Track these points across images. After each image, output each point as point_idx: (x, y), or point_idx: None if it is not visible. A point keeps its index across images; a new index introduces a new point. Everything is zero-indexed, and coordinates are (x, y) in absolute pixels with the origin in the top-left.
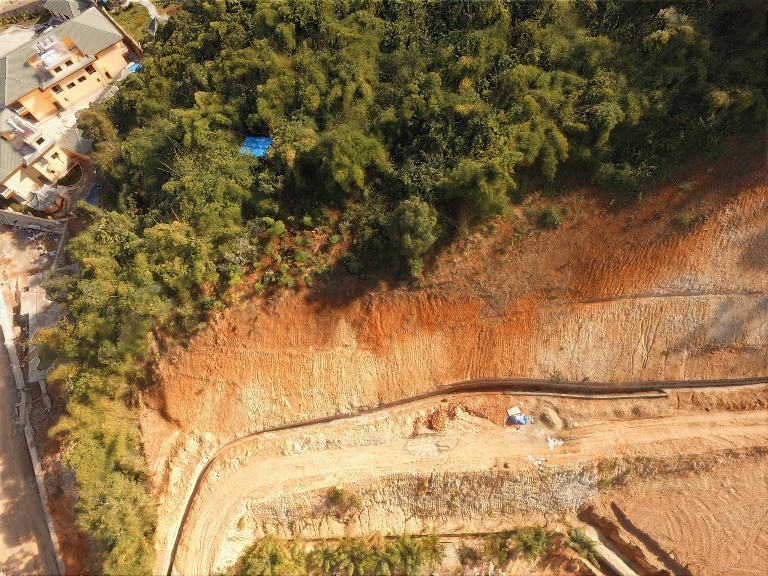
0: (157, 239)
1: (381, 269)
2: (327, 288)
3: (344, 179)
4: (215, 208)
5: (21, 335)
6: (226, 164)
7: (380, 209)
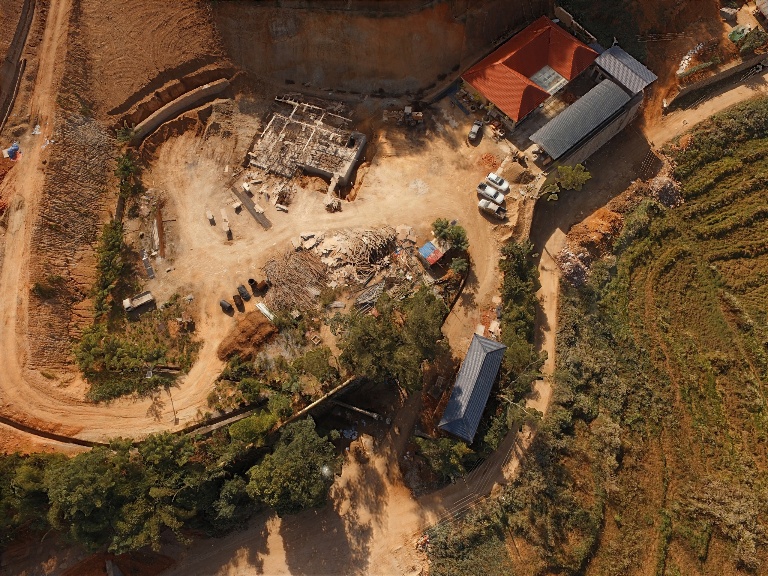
0: None
1: None
2: None
3: None
4: None
5: None
6: None
7: None
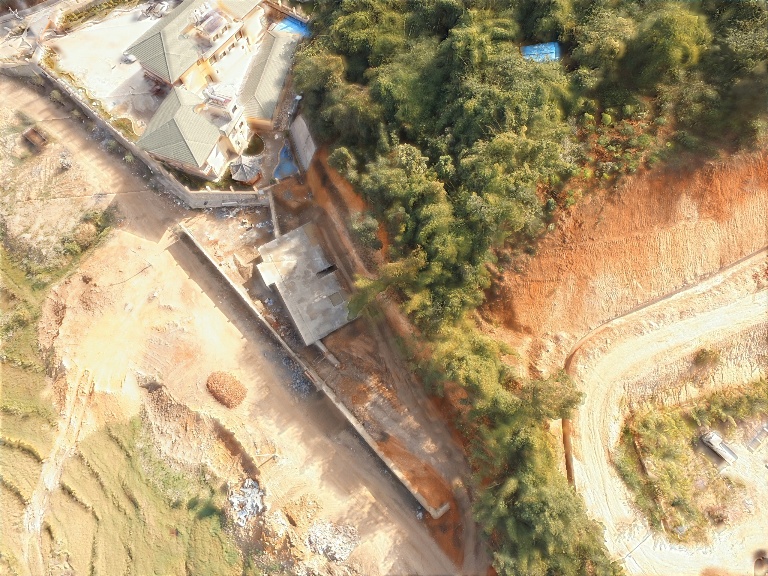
0: (506, 147)
1: (714, 138)
2: (668, 166)
3: (674, 57)
4: (546, 110)
5: (265, 308)
6: (540, 67)
7: (697, 84)
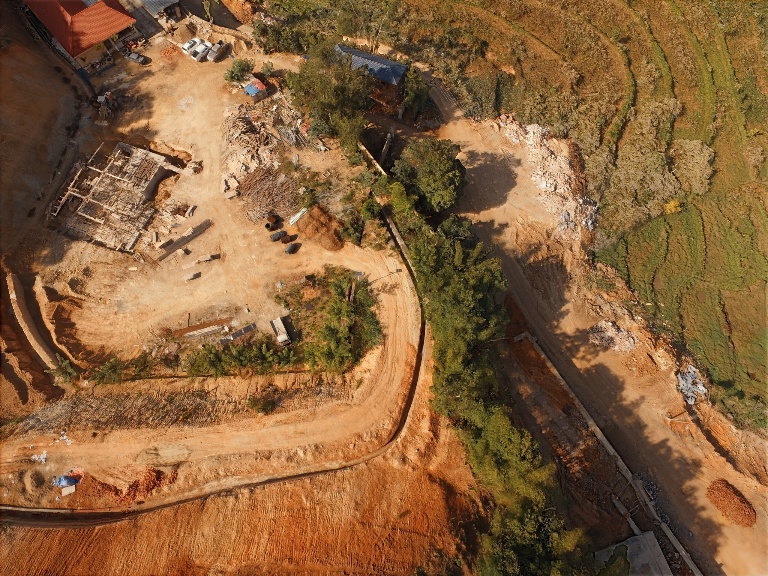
0: None
1: None
2: None
3: None
4: None
5: None
6: None
7: None
